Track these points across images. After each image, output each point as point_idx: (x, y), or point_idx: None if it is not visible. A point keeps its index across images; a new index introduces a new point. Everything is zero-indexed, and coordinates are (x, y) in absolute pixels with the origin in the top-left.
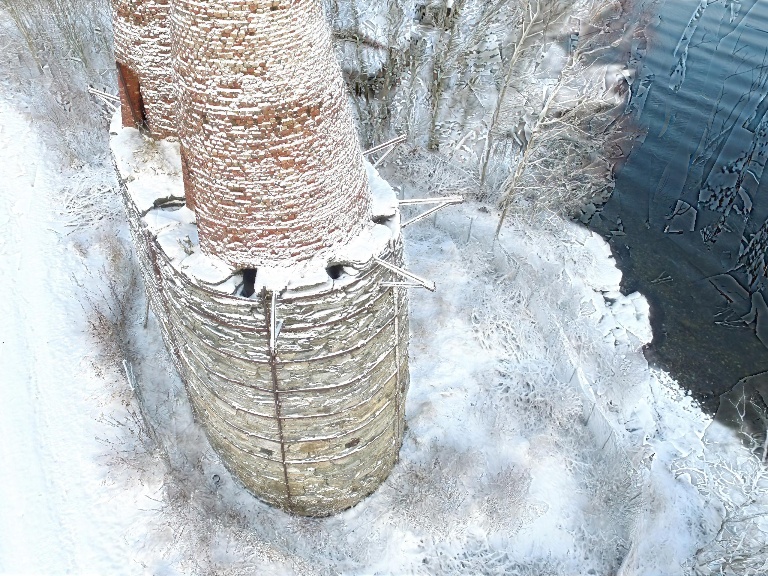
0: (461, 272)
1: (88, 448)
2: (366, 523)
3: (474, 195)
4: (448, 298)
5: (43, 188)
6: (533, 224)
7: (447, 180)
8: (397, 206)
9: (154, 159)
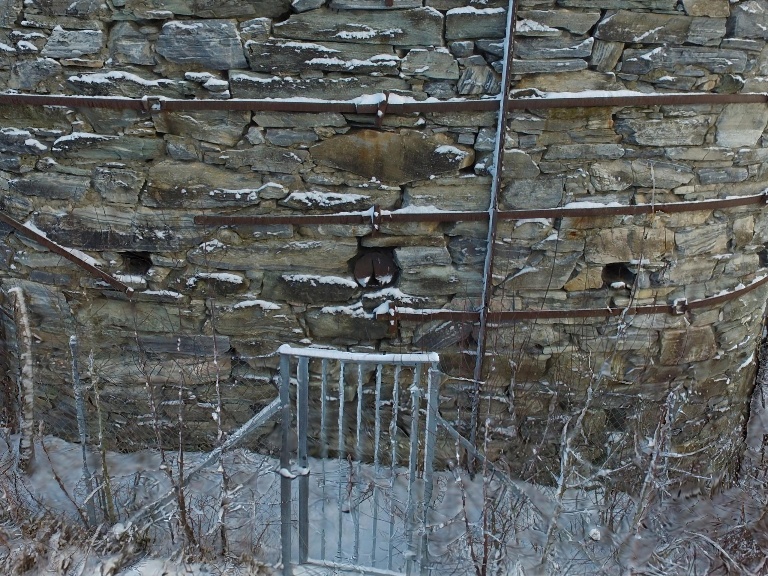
0: None
1: None
2: (760, 417)
3: None
4: None
5: None
6: None
7: None
8: None
9: None
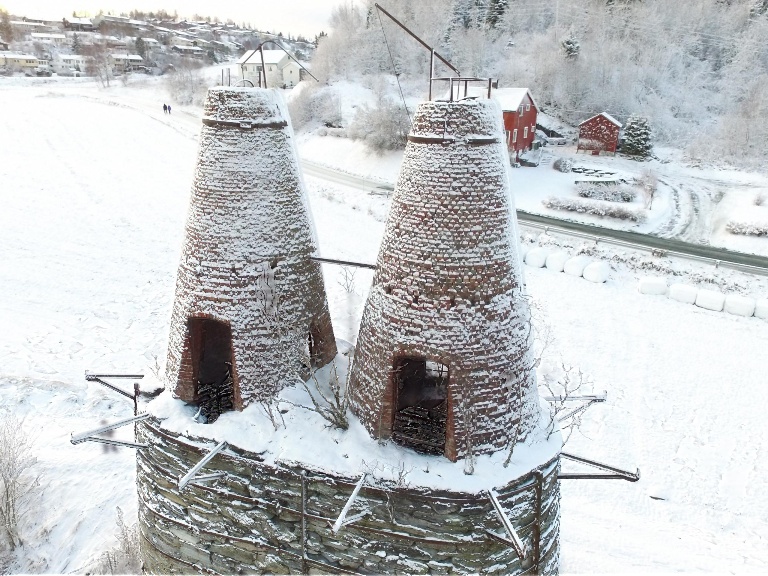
0: None
1: None
2: None
3: None
4: None
5: None
6: None
7: None
8: None
9: None
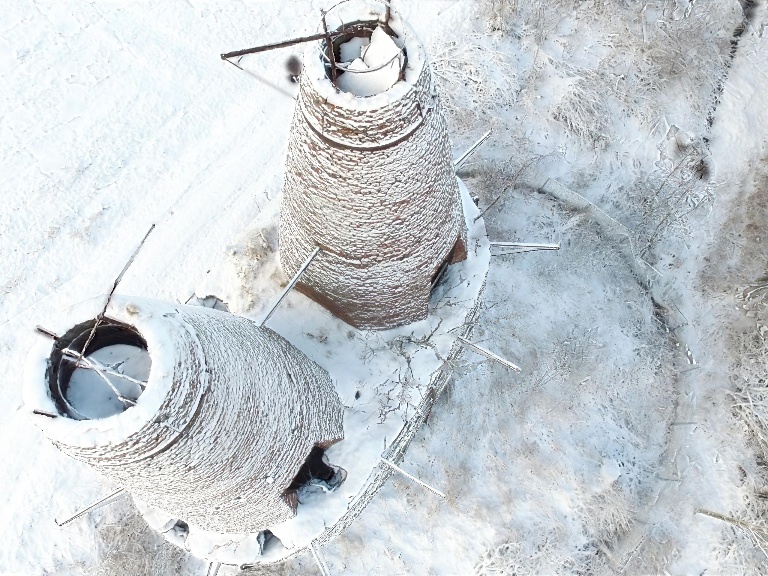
0: (575, 503)
1: (198, 281)
2: None
3: (762, 452)
4: (521, 505)
5: (442, 24)
6: (759, 548)
7: (764, 408)
8: (300, 546)
9: (252, 260)
